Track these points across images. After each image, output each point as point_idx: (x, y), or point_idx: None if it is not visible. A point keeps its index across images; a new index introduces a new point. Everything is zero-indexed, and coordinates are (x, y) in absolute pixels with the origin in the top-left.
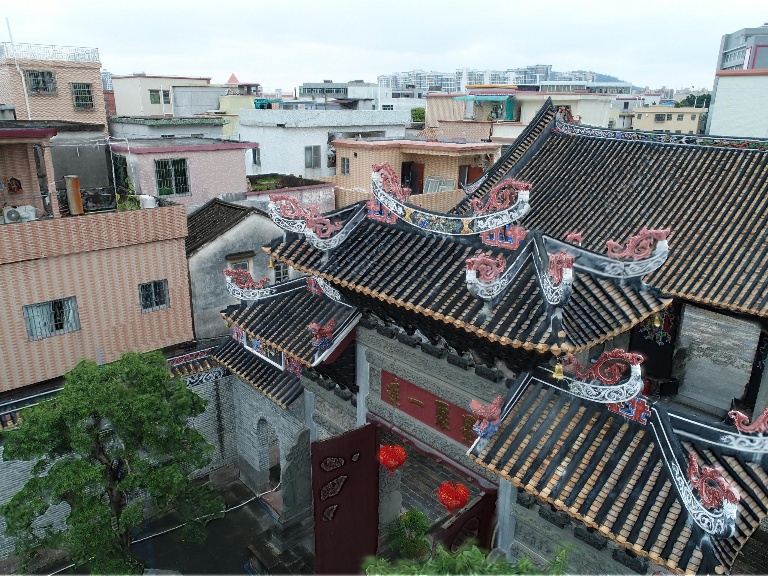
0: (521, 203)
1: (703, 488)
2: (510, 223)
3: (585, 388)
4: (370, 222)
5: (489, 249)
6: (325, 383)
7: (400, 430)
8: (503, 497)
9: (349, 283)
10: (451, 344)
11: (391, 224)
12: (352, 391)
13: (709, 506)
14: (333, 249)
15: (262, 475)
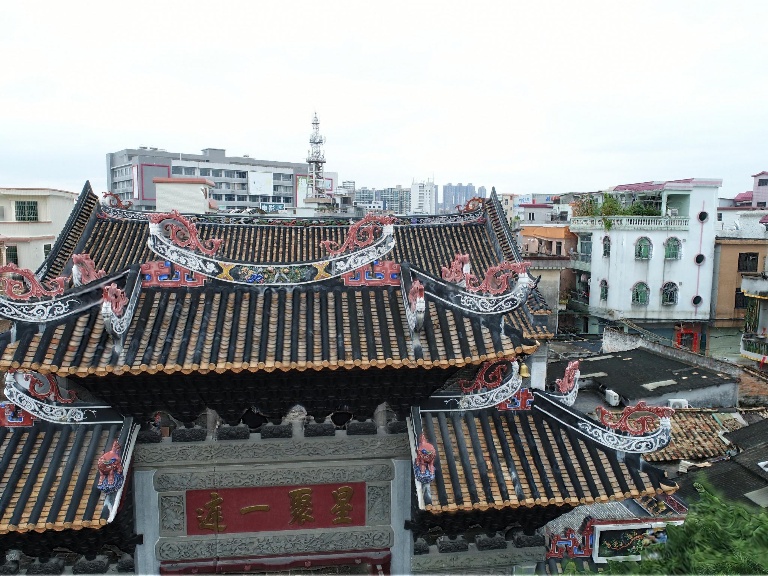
0: (389, 237)
1: (627, 424)
2: (378, 258)
3: (474, 399)
4: (153, 291)
5: (355, 290)
6: (49, 566)
7: (229, 561)
8: (400, 557)
9: (200, 365)
10: (313, 411)
11: (194, 288)
12: (125, 549)
13: (642, 433)
14: (125, 332)
15: None
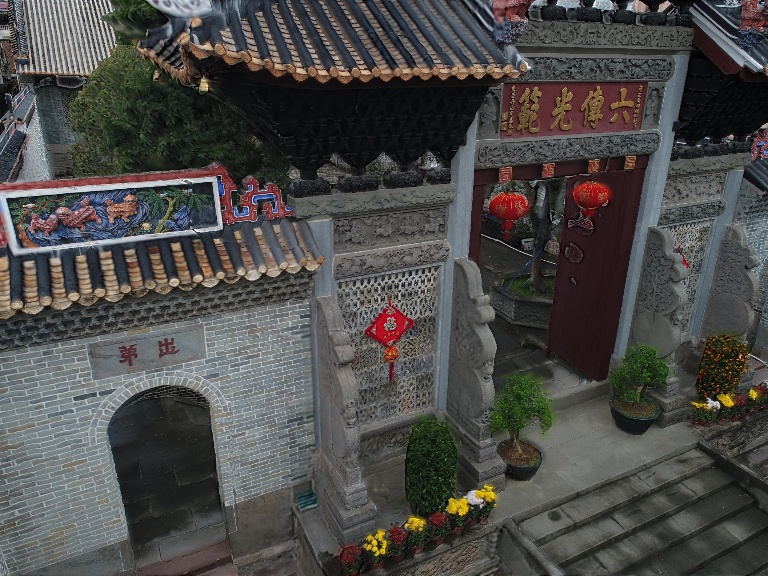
0: None
1: None
2: None
3: None
4: None
5: None
6: None
7: None
8: None
9: None
10: None
11: None
12: None
13: None
14: None
15: (762, 332)
